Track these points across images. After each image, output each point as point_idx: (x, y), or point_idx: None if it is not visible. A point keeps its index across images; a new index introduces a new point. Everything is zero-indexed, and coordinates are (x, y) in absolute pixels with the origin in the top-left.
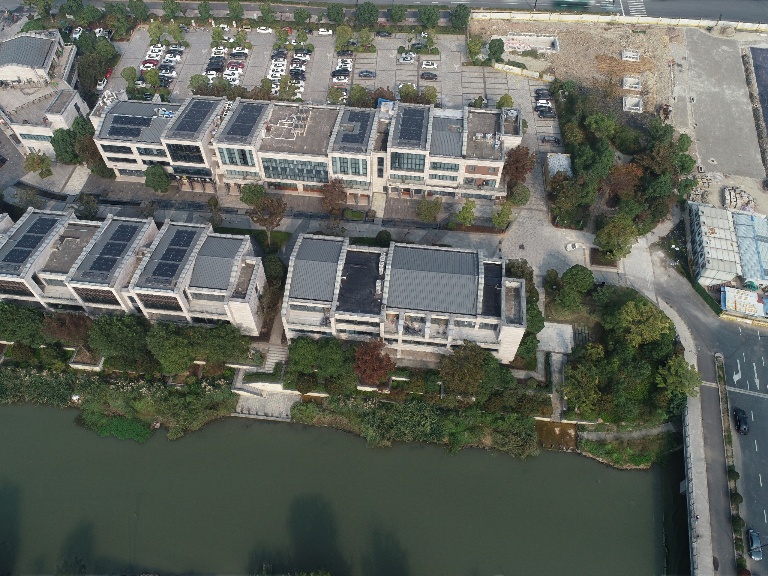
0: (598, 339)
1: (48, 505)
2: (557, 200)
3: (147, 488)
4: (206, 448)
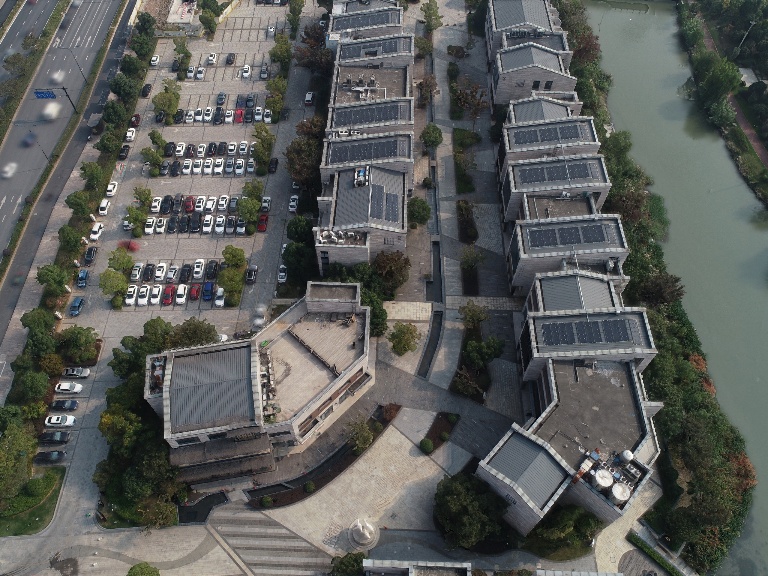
0: None
1: (731, 241)
2: None
3: (691, 188)
4: (648, 165)
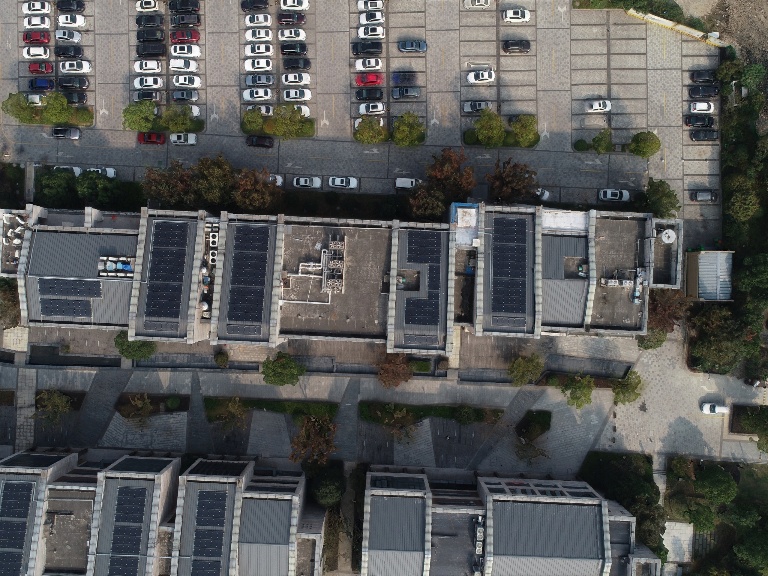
0: (721, 542)
1: None
2: (707, 363)
3: None
4: None
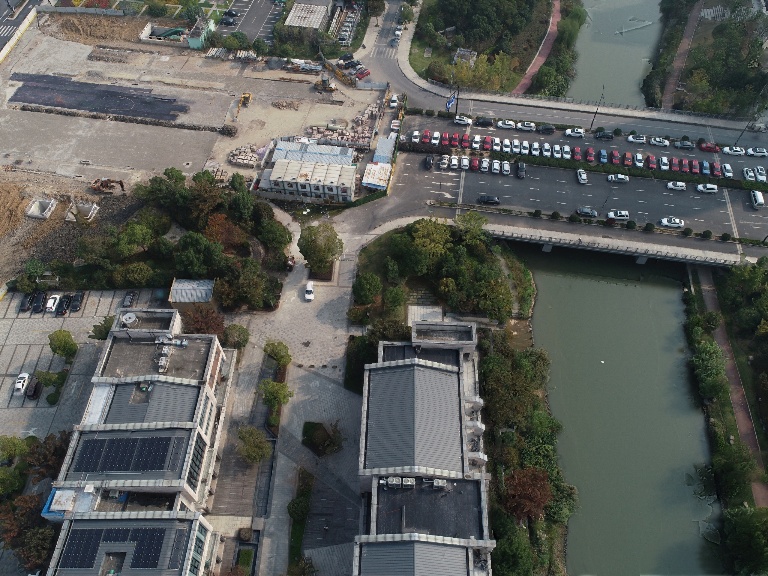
0: (423, 286)
1: None
2: None
3: None
4: None
